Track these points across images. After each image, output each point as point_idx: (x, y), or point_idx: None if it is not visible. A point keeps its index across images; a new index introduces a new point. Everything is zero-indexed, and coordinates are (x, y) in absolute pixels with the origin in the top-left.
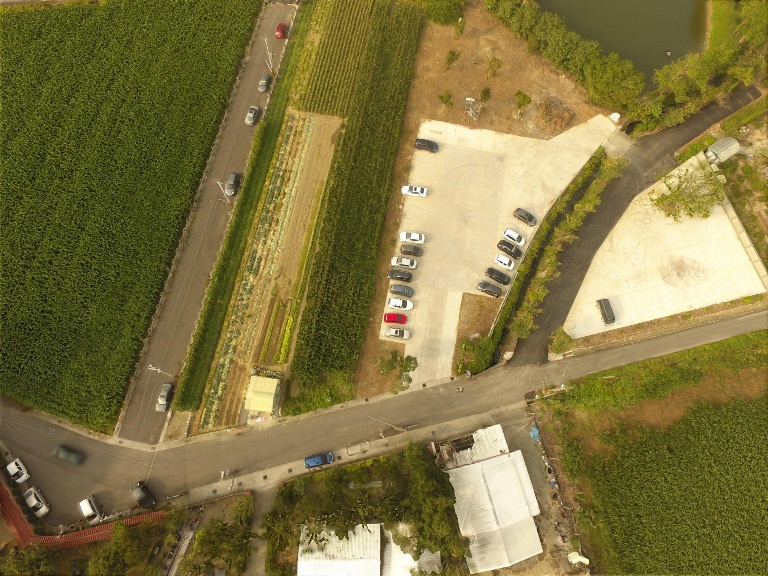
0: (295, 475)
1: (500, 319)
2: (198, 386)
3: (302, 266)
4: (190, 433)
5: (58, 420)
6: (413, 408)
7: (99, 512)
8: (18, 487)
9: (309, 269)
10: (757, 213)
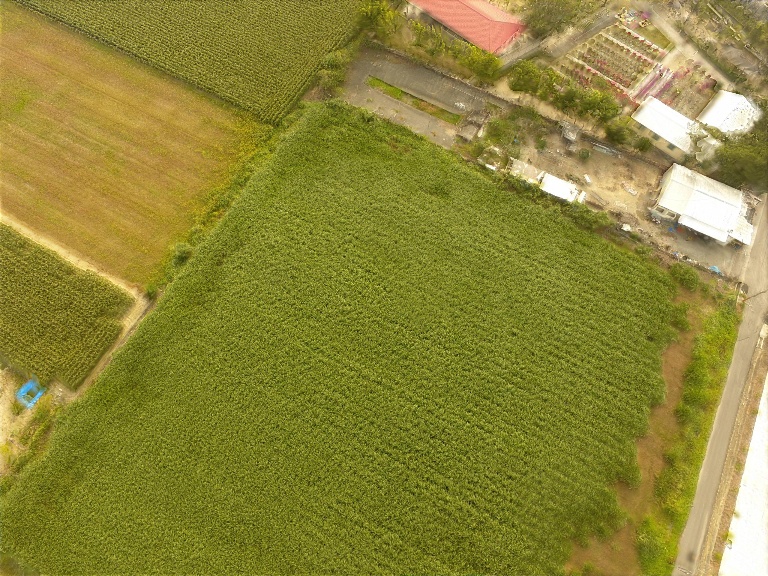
0: None
1: None
2: None
3: None
4: None
5: None
6: None
7: None
8: None
9: None
10: None
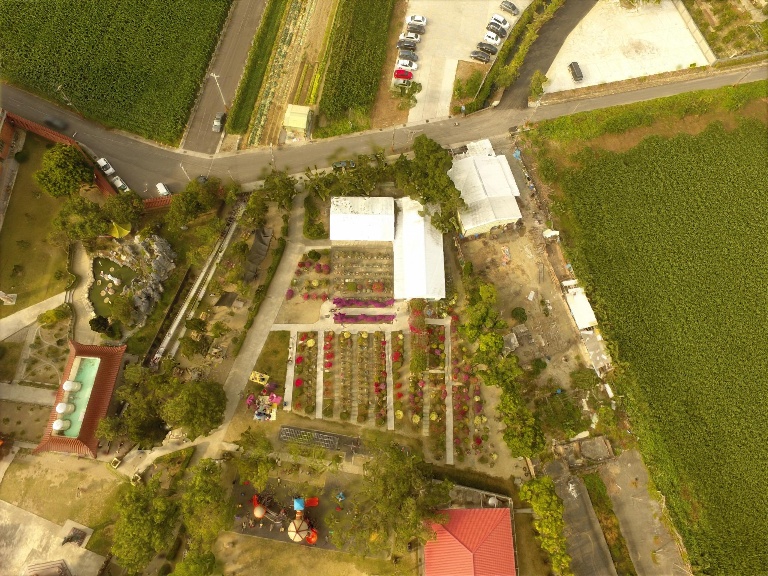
0: None
1: (489, 77)
2: (245, 118)
3: (326, 40)
4: (240, 149)
5: (134, 136)
6: (418, 135)
7: (171, 194)
8: (106, 178)
9: (332, 42)
10: (703, 10)
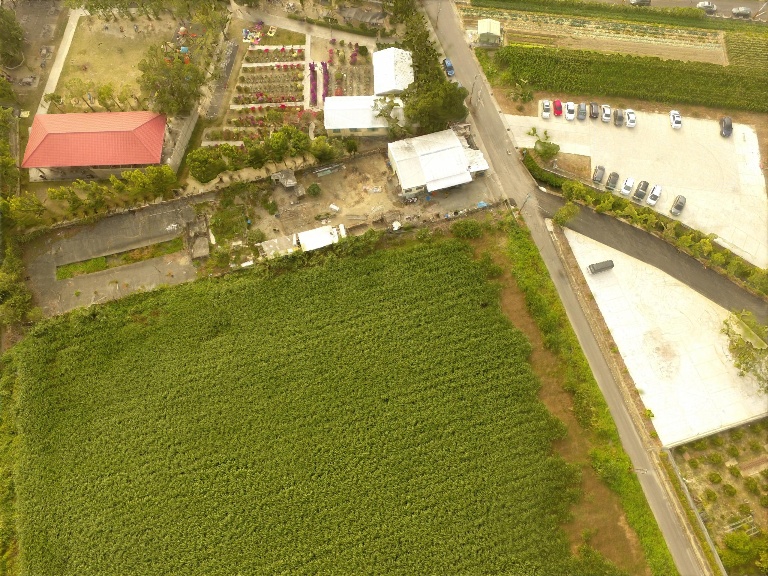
0: None
1: None
2: (487, 3)
3: None
4: (457, 4)
5: None
6: (491, 122)
7: None
8: None
9: None
10: (765, 457)
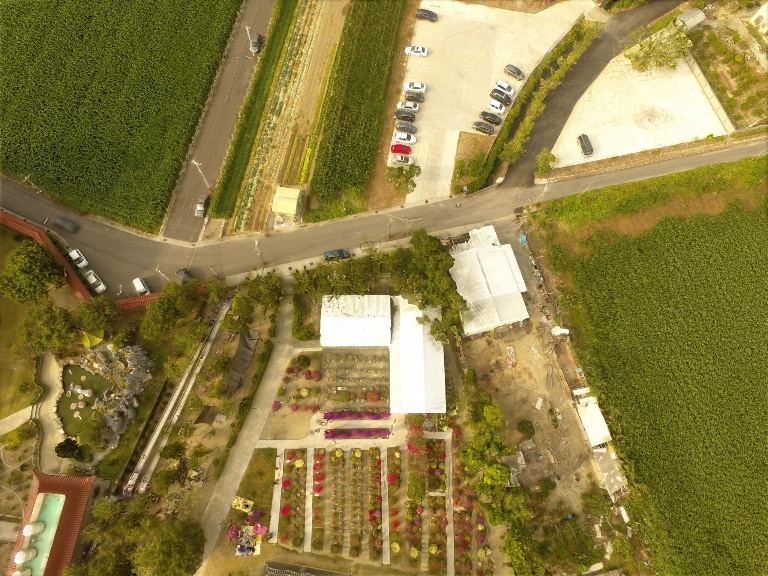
0: (316, 267)
1: (492, 151)
2: (230, 199)
3: (318, 110)
4: (224, 235)
5: (111, 223)
6: None
7: (149, 290)
8: (79, 271)
9: (325, 112)
10: (720, 72)
